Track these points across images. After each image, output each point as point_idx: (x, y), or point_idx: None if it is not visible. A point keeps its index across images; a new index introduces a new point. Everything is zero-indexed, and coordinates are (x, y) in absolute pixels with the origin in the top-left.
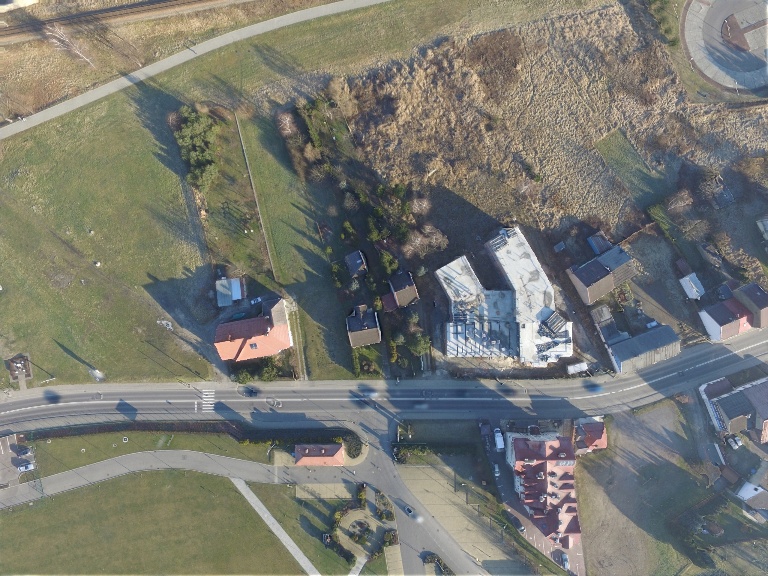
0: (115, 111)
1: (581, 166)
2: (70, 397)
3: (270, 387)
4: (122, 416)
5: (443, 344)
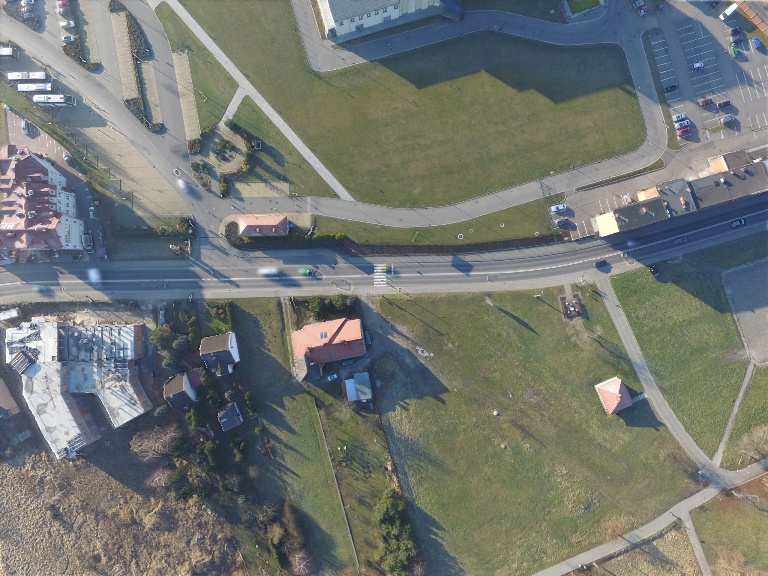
0: (486, 575)
1: (4, 518)
2: (520, 277)
3: (319, 290)
4: (466, 259)
5: (145, 335)
